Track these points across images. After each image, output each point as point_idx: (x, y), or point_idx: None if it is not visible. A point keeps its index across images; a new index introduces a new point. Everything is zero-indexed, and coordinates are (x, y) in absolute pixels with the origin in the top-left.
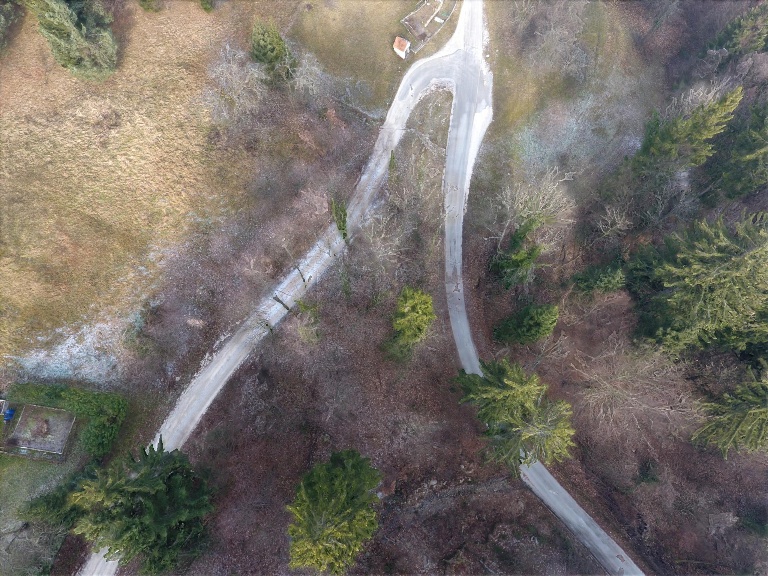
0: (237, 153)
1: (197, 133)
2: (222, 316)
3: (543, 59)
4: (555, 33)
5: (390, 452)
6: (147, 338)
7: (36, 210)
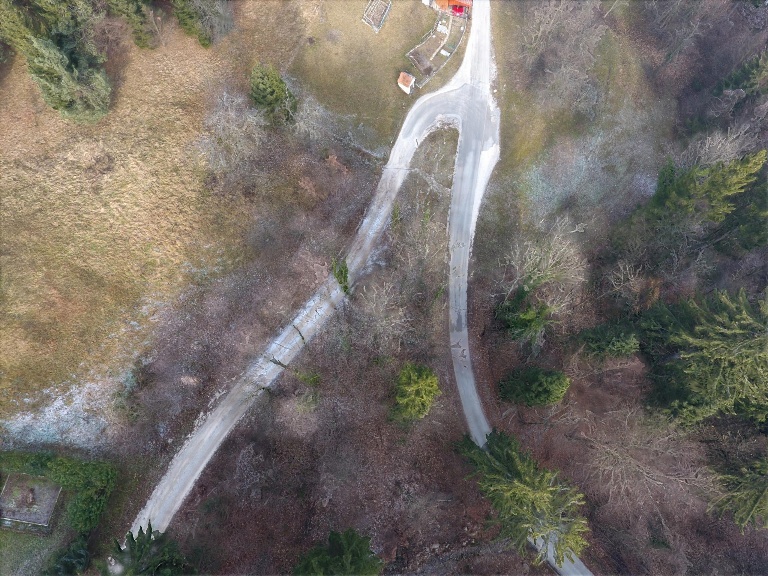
0: (235, 199)
1: (193, 178)
2: (217, 372)
3: (553, 97)
4: (566, 71)
5: (391, 515)
6: (138, 400)
7: (24, 262)
